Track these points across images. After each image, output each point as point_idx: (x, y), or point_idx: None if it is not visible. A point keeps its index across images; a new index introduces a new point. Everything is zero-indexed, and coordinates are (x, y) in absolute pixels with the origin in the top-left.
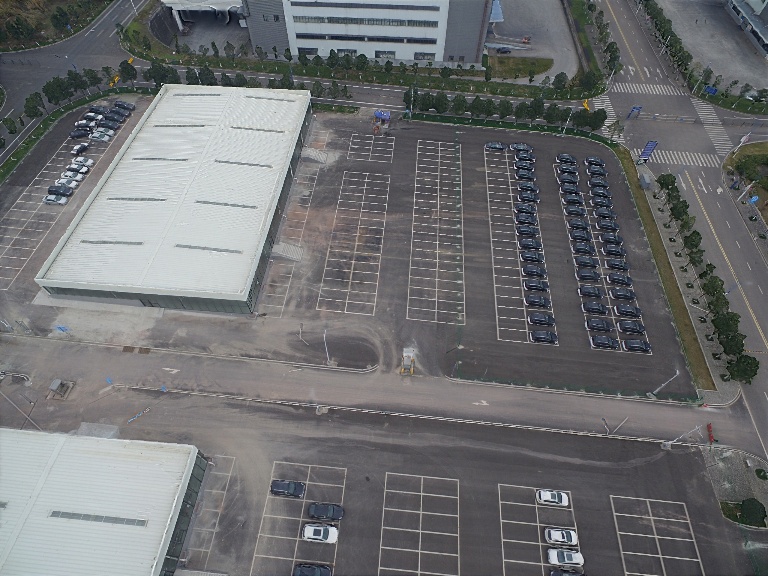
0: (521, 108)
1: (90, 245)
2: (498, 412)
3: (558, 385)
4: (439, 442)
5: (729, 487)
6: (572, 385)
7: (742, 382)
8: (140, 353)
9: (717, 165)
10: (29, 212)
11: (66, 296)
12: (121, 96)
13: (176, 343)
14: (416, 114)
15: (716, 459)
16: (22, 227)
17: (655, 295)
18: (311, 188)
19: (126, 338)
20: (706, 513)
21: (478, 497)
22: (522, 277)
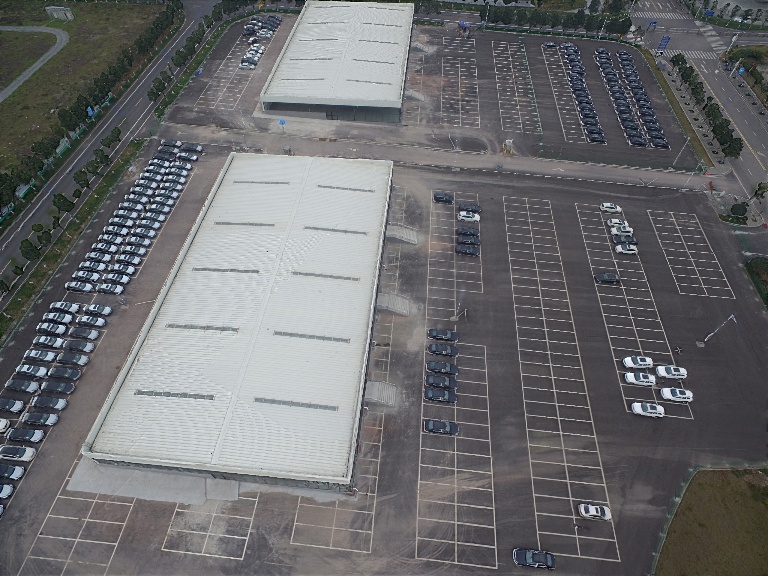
0: (568, 19)
1: (288, 81)
2: (570, 174)
3: (609, 162)
4: (534, 185)
5: (724, 209)
6: (618, 163)
7: (733, 165)
8: (330, 141)
9: (715, 58)
10: (231, 73)
11: (275, 112)
12: (269, 14)
13: (353, 137)
14: (488, 27)
15: (715, 197)
16: (229, 80)
17: (672, 122)
18: (421, 65)
19: (319, 134)
20: (709, 219)
21: (563, 208)
22: (578, 112)
